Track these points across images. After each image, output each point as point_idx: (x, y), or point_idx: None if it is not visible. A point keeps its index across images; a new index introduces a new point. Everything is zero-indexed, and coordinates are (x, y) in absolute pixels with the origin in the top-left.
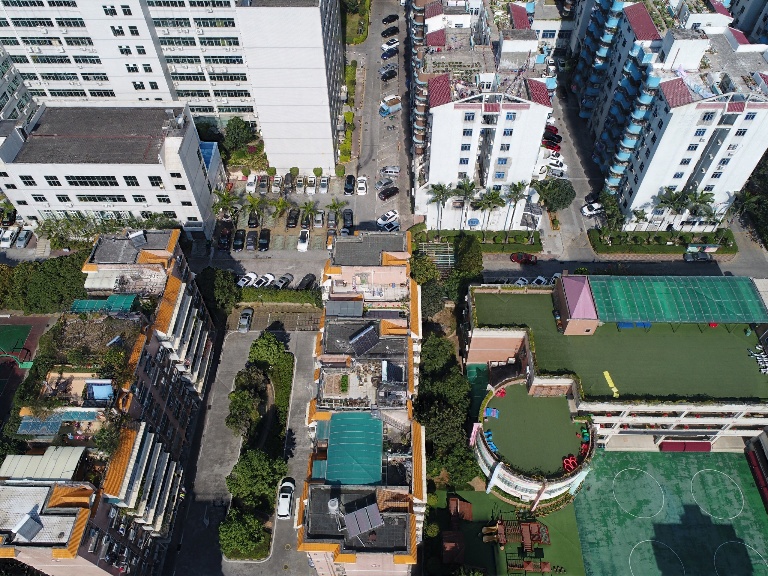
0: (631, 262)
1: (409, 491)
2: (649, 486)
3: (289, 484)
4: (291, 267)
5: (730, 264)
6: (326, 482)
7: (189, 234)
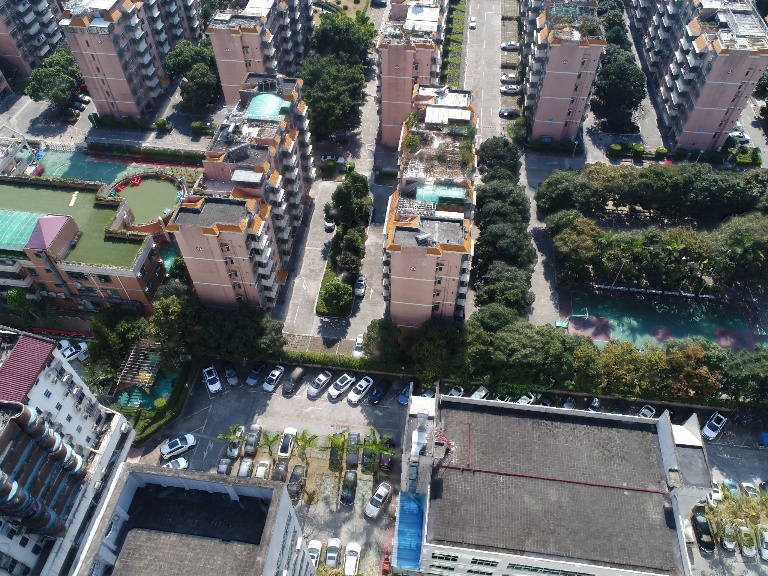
0: None
1: (241, 108)
2: None
3: (328, 224)
4: (308, 409)
5: None
6: (283, 98)
7: None
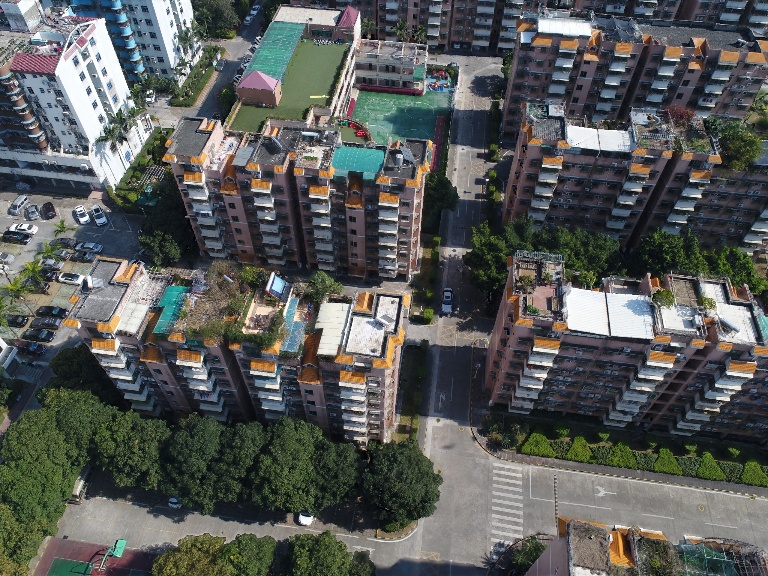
0: (209, 94)
1: None
2: (370, 129)
3: None
4: None
5: (232, 56)
6: None
7: (5, 376)
